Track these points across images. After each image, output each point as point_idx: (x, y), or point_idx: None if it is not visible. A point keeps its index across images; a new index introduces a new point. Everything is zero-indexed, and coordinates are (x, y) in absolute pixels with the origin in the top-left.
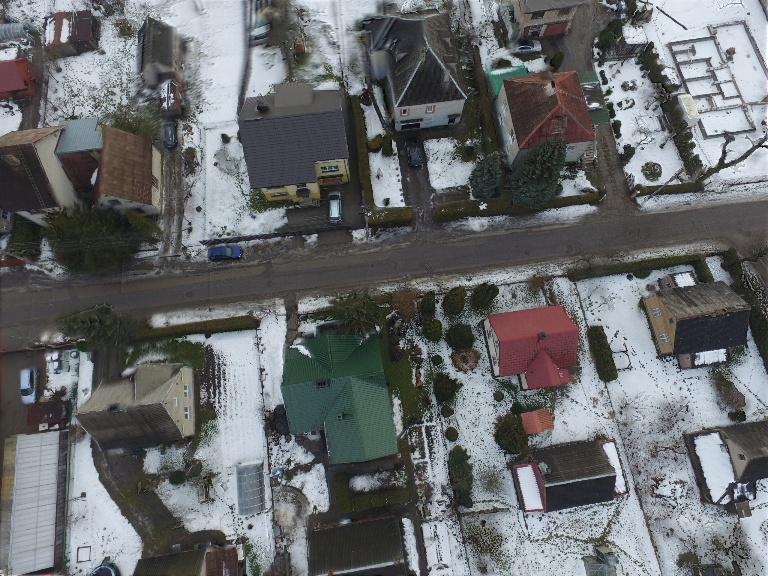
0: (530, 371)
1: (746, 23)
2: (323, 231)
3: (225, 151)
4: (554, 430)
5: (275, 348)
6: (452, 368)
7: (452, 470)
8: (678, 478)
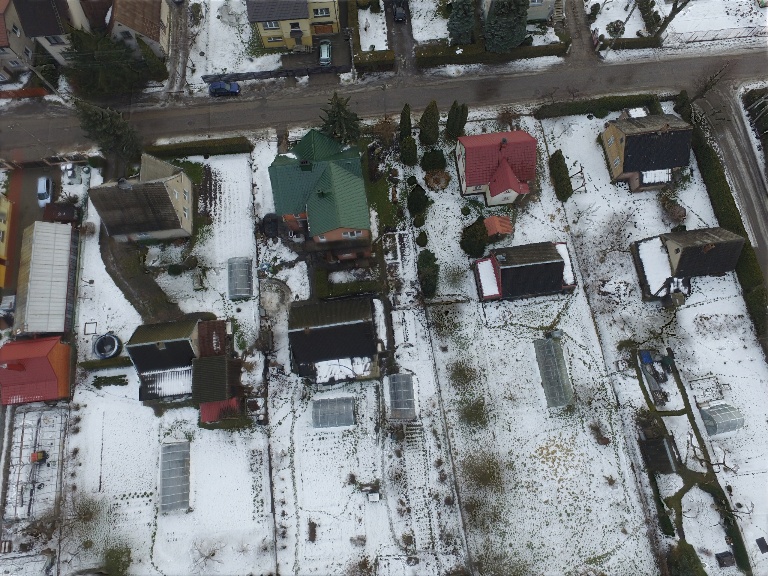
0: (493, 180)
1: None
2: (314, 73)
3: (227, 6)
4: (514, 239)
5: (266, 168)
6: (425, 188)
7: (420, 266)
8: (623, 280)
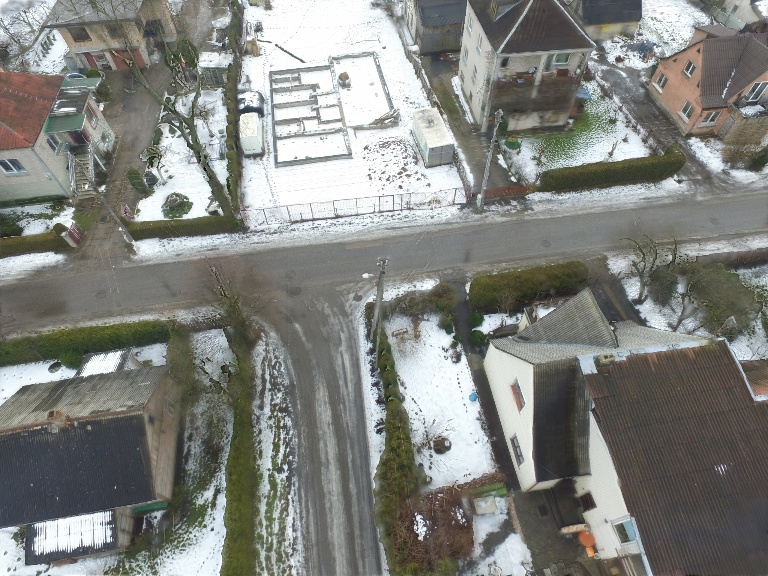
0: None
1: (374, 54)
2: None
3: None
4: None
5: None
6: None
7: None
8: None
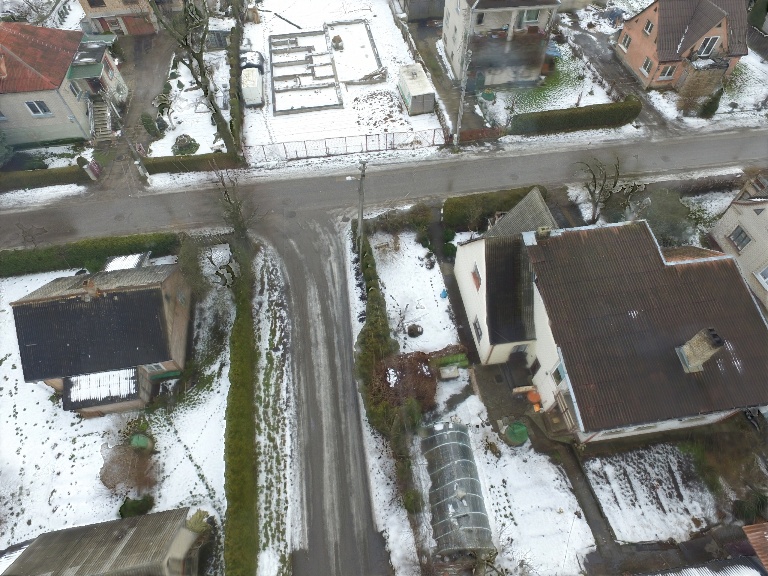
0: None
1: (366, 20)
2: None
3: None
4: None
5: None
6: None
7: None
8: None
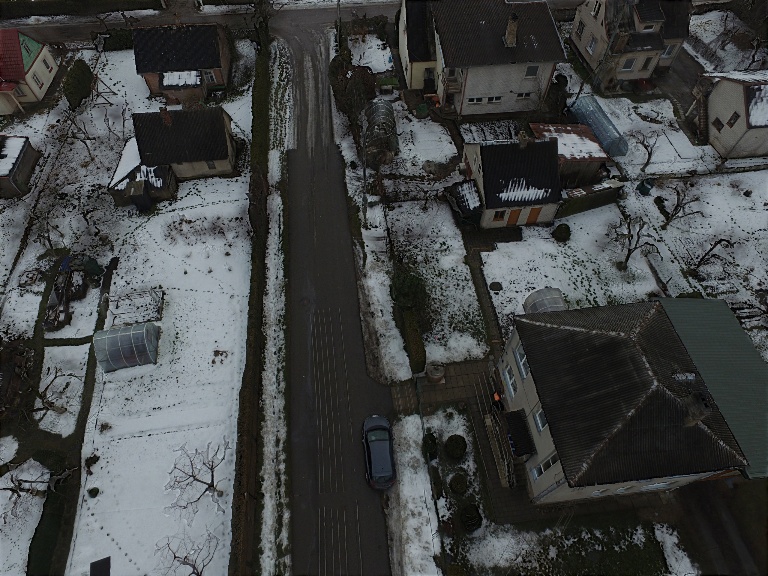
0: None
1: None
2: None
3: None
4: None
5: None
6: None
7: None
8: (99, 183)
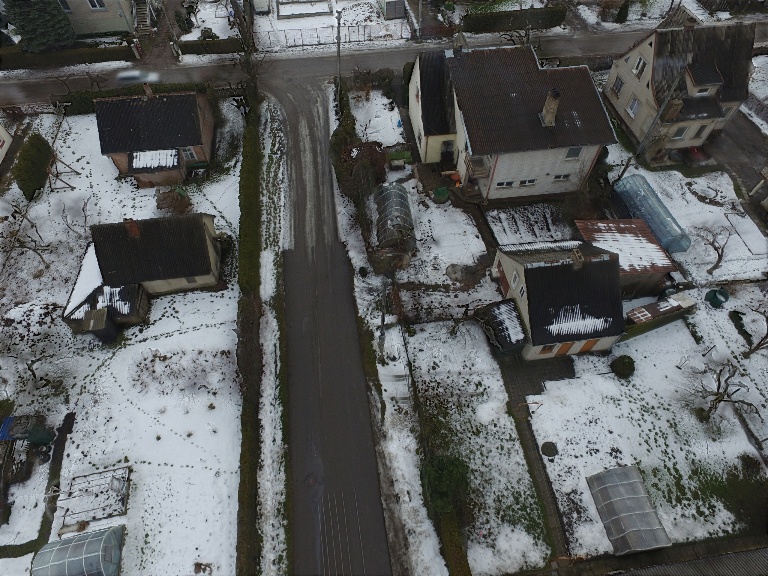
0: None
1: None
2: None
3: None
4: None
5: None
6: None
7: None
8: (54, 302)
